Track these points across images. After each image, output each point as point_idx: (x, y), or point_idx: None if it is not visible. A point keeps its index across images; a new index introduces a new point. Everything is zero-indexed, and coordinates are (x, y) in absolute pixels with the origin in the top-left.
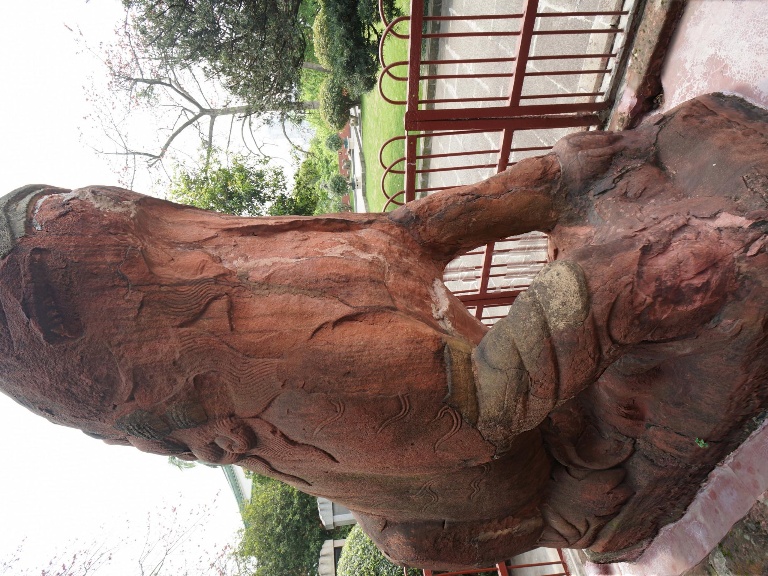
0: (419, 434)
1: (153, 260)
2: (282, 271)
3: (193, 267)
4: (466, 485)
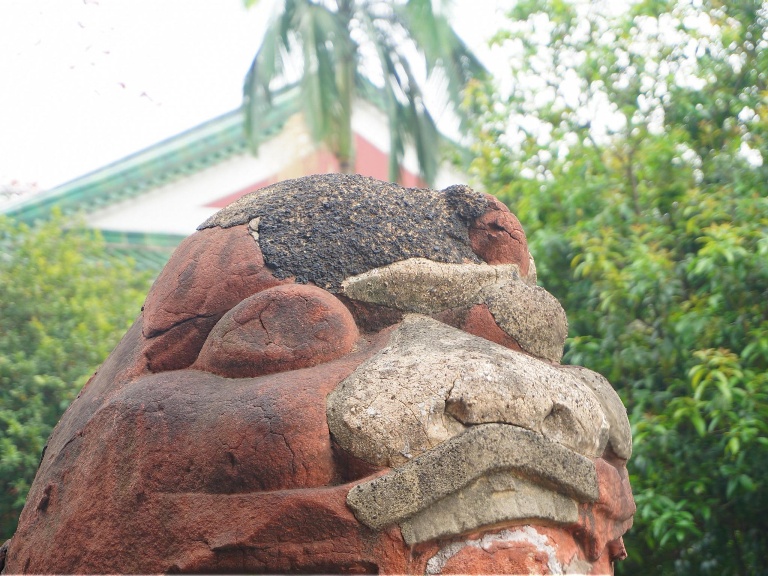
0: None
1: None
2: None
3: None
4: None
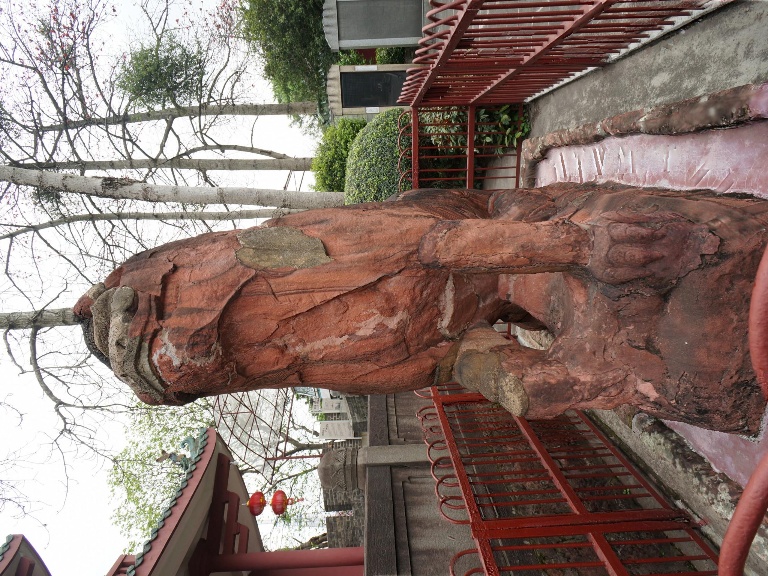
0: None
1: (243, 365)
2: (332, 353)
3: (271, 362)
4: None
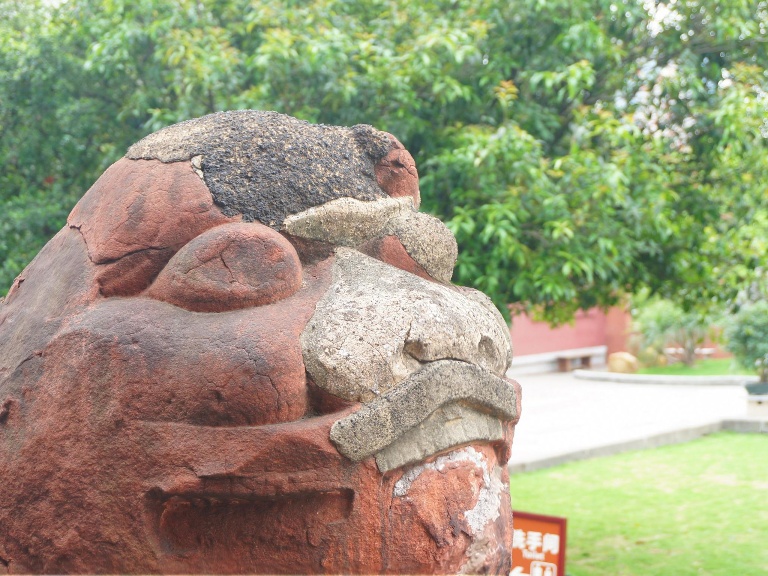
0: None
1: None
2: None
3: None
4: None
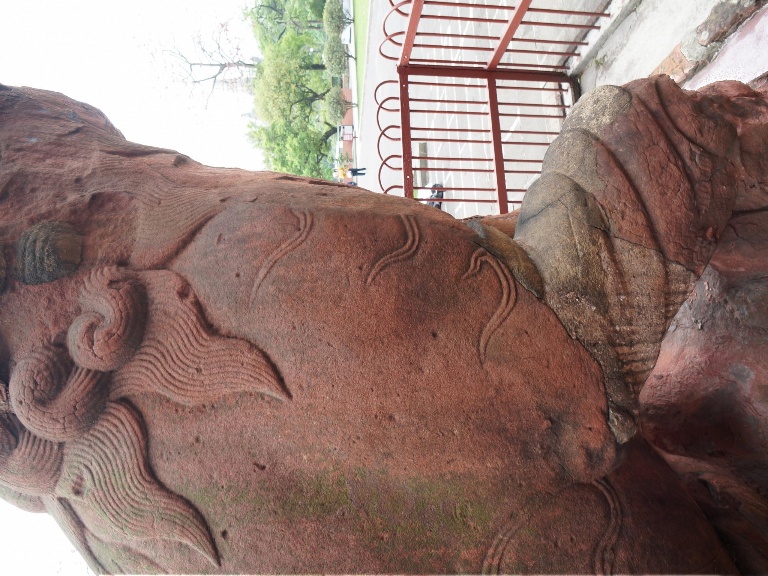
0: (444, 306)
1: None
2: None
3: None
4: (584, 569)
